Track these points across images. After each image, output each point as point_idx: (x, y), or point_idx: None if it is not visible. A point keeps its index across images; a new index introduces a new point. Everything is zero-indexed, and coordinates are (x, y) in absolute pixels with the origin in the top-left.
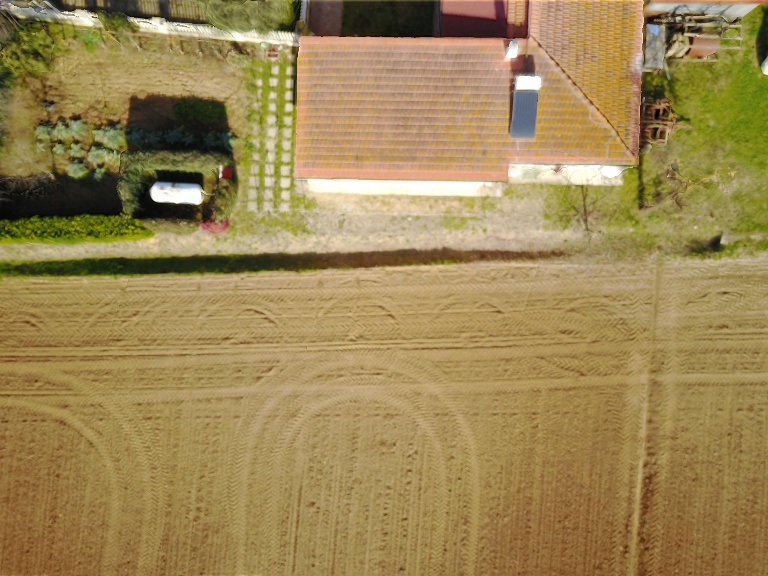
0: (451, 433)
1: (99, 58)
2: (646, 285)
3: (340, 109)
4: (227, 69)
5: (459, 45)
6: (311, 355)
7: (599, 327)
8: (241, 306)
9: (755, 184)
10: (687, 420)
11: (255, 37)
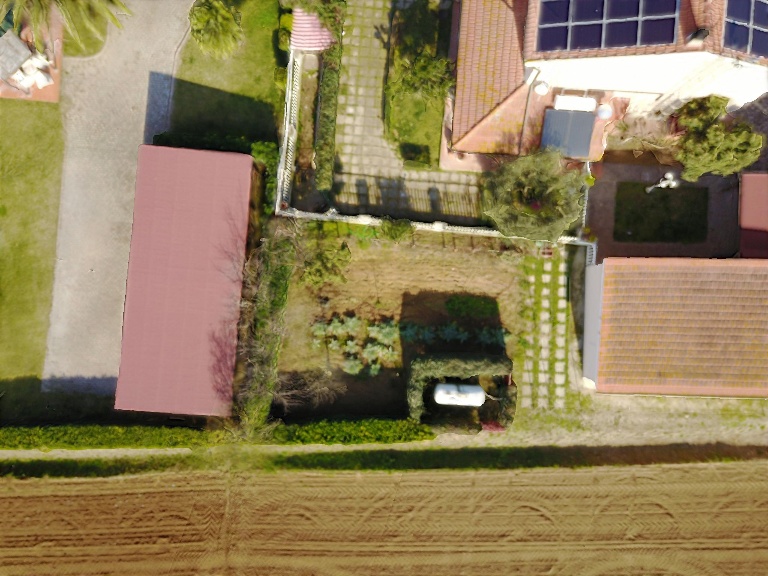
0: None
1: (372, 255)
2: None
3: (644, 327)
4: (499, 265)
5: None
6: (589, 554)
7: None
8: (516, 503)
9: None
10: None
11: None
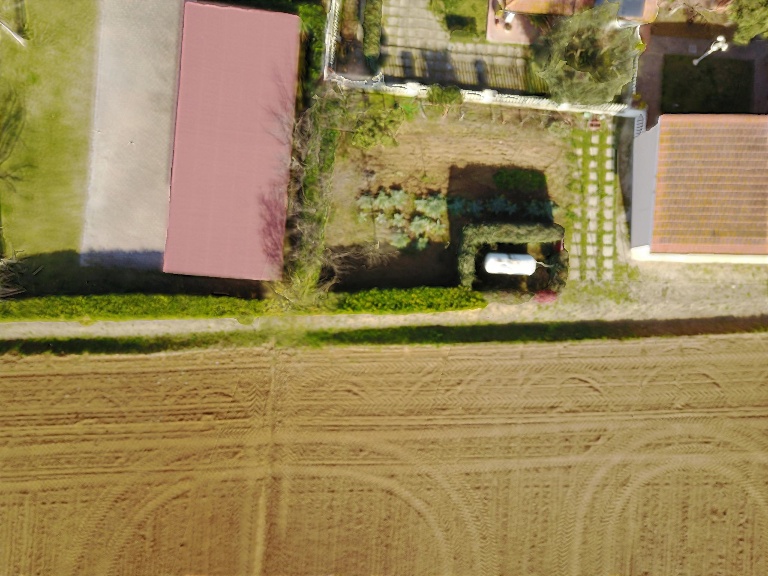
0: None
1: (419, 128)
2: None
3: (699, 185)
4: (547, 138)
5: None
6: (637, 424)
7: None
8: (565, 374)
9: None
10: None
11: (580, 108)
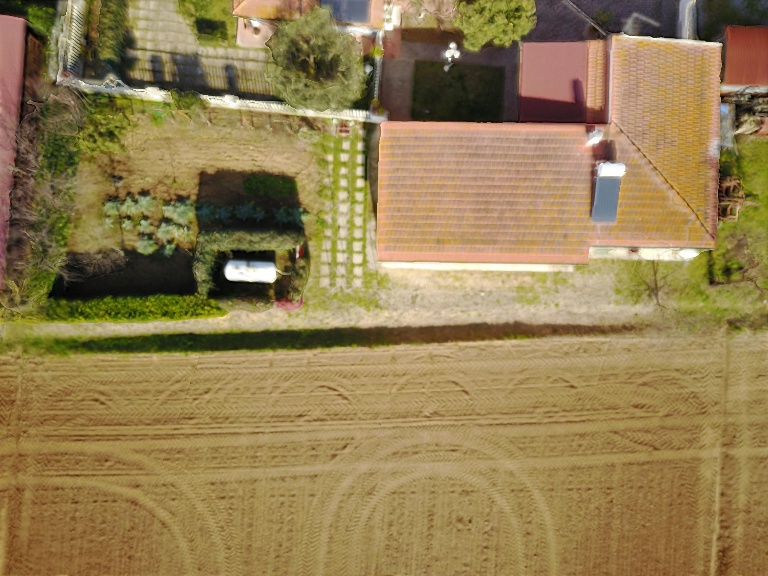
0: (526, 509)
1: (168, 133)
2: (716, 358)
3: (422, 193)
4: (298, 144)
5: (541, 130)
6: (385, 432)
7: (671, 401)
8: (314, 383)
9: None
10: (759, 493)
11: (327, 114)
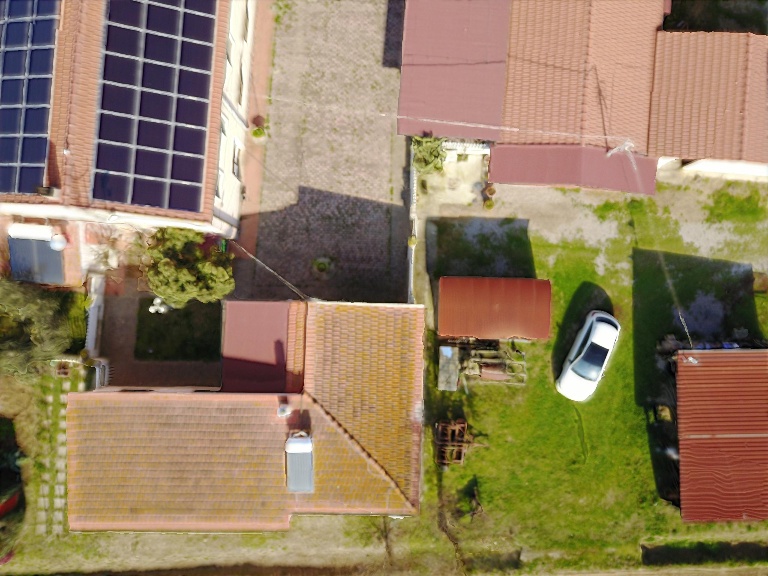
0: None
1: None
2: None
3: (112, 463)
4: (16, 385)
5: (233, 400)
6: None
7: None
8: None
9: (552, 500)
10: None
11: None
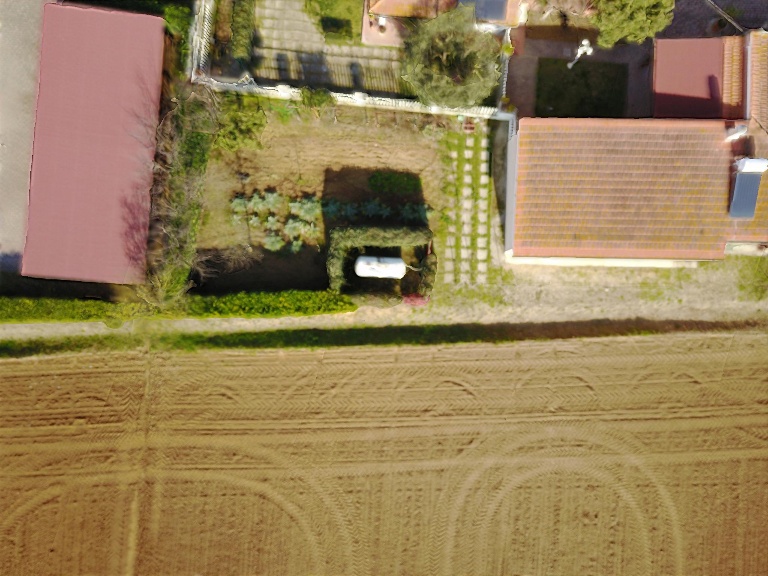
0: (652, 504)
1: (294, 131)
2: None
3: (559, 189)
4: (422, 141)
5: (680, 126)
6: (510, 427)
7: None
8: (439, 378)
9: None
10: None
11: (453, 111)
